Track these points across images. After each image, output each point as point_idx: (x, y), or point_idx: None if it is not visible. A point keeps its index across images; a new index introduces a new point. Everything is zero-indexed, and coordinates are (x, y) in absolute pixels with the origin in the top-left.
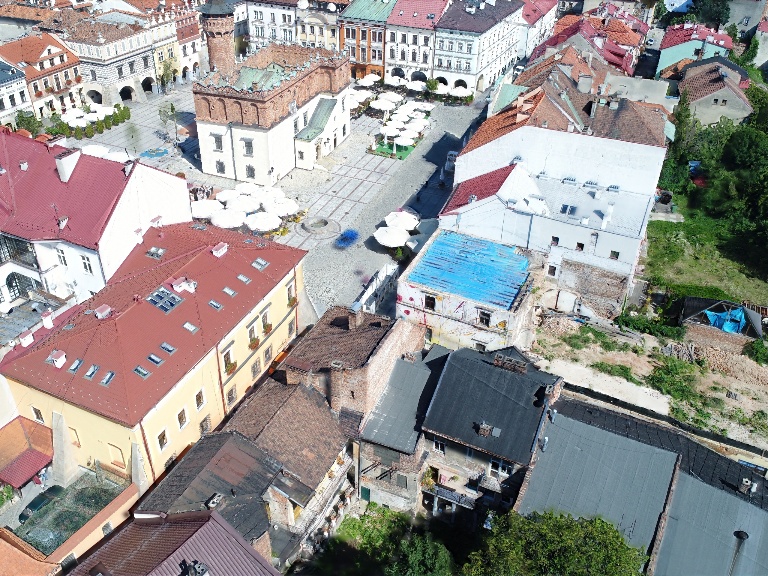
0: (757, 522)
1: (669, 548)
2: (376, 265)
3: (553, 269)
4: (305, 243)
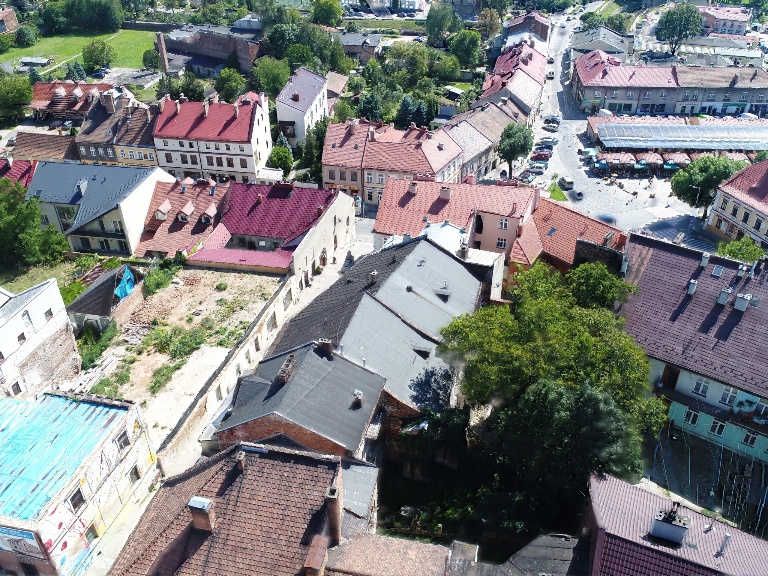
0: (401, 279)
1: (421, 326)
2: None
3: (16, 387)
4: None
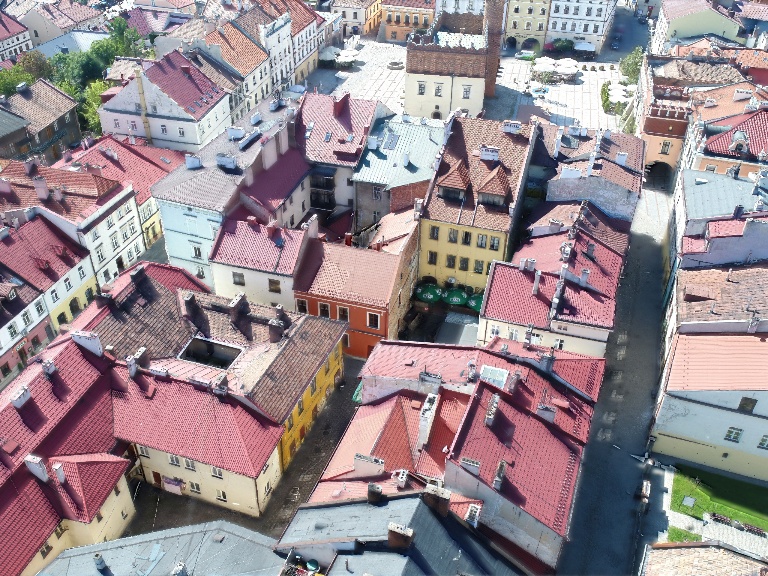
0: None
1: None
2: (357, 56)
3: None
4: (398, 61)
